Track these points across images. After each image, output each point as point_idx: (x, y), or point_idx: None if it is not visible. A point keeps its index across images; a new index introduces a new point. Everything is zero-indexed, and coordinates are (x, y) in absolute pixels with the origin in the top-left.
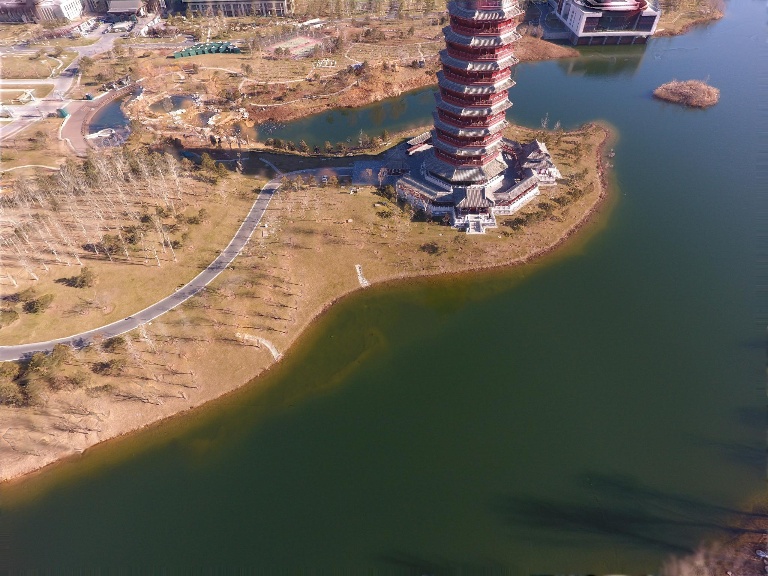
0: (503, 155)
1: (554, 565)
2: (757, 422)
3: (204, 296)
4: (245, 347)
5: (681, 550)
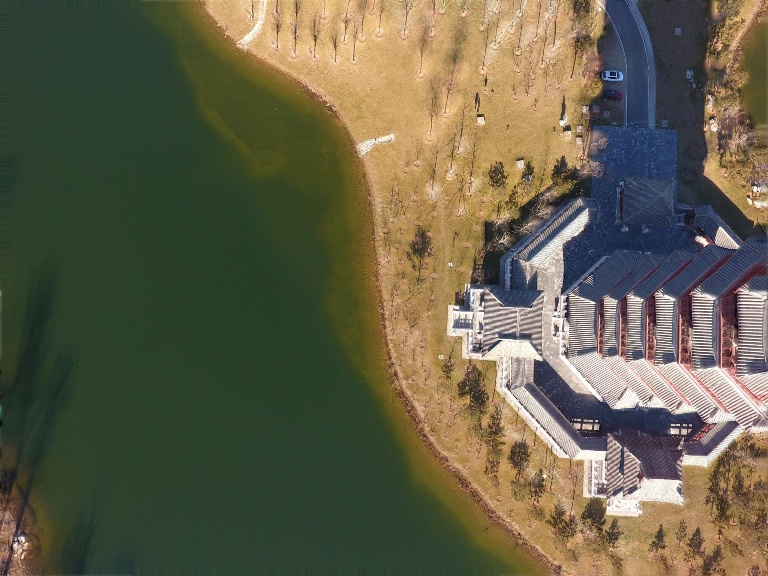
0: (688, 420)
1: (5, 304)
2: (118, 569)
3: None
4: (250, 0)
5: (2, 419)
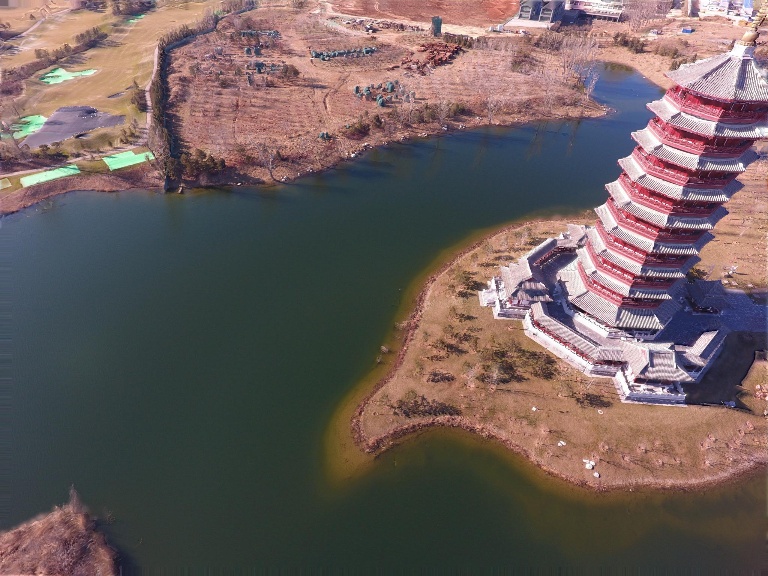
0: None
1: None
2: (416, 153)
3: (764, 196)
4: None
5: None
